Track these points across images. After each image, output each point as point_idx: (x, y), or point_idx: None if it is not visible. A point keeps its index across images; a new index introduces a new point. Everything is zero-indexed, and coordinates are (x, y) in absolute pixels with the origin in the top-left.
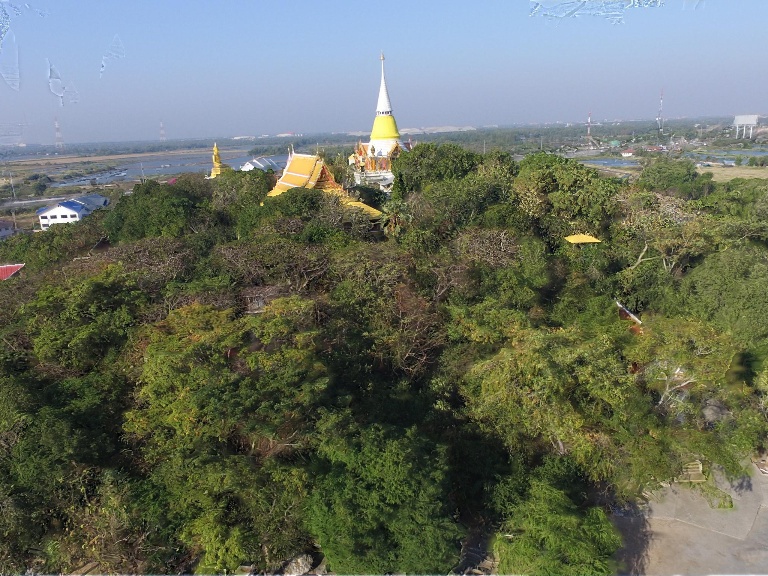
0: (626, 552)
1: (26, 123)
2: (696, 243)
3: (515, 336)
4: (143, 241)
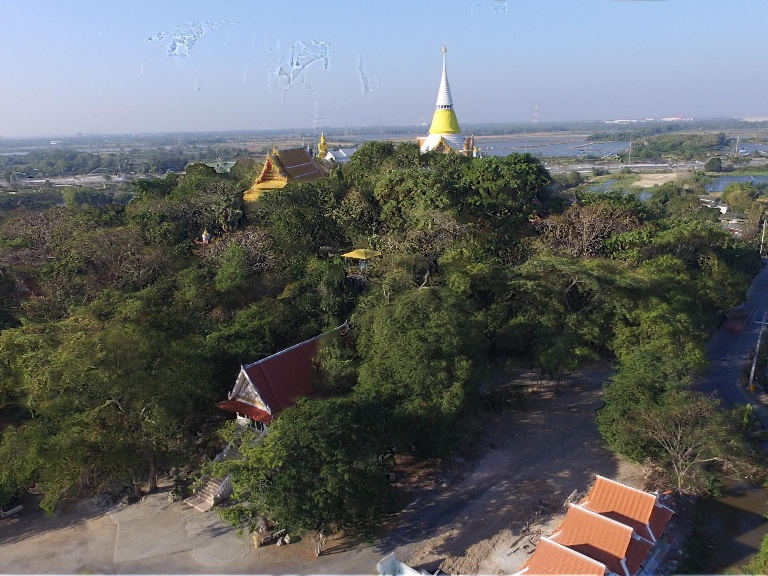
0: (41, 525)
1: (335, 109)
2: (393, 274)
3: None
4: None
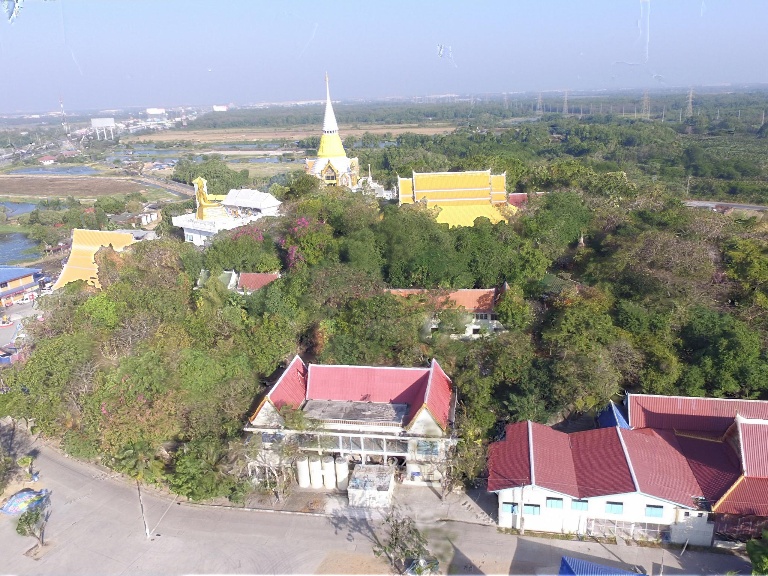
0: None
1: None
2: None
3: (760, 231)
4: (665, 236)
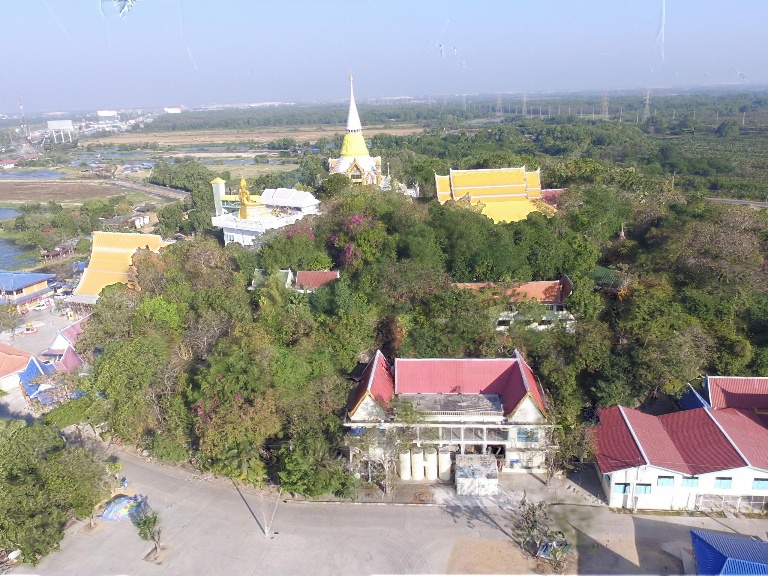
0: None
1: None
2: None
3: None
4: (711, 227)
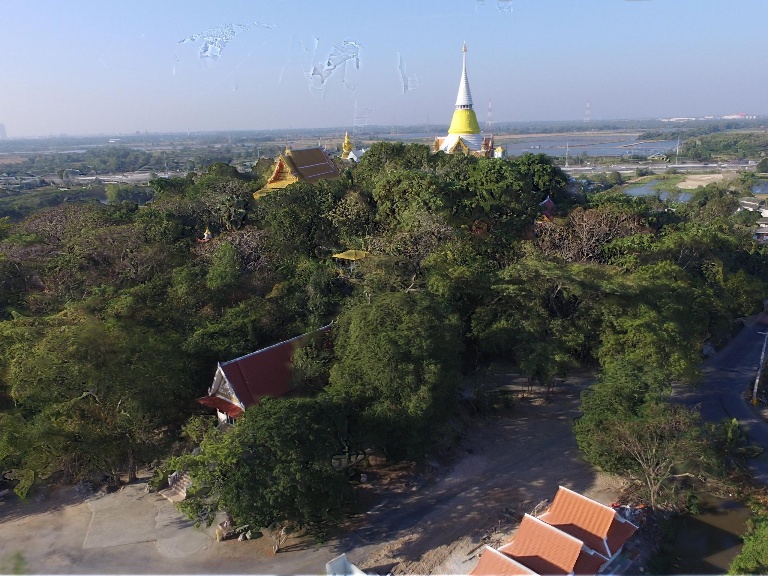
0: (24, 509)
1: (375, 108)
2: (372, 276)
3: None
4: None
